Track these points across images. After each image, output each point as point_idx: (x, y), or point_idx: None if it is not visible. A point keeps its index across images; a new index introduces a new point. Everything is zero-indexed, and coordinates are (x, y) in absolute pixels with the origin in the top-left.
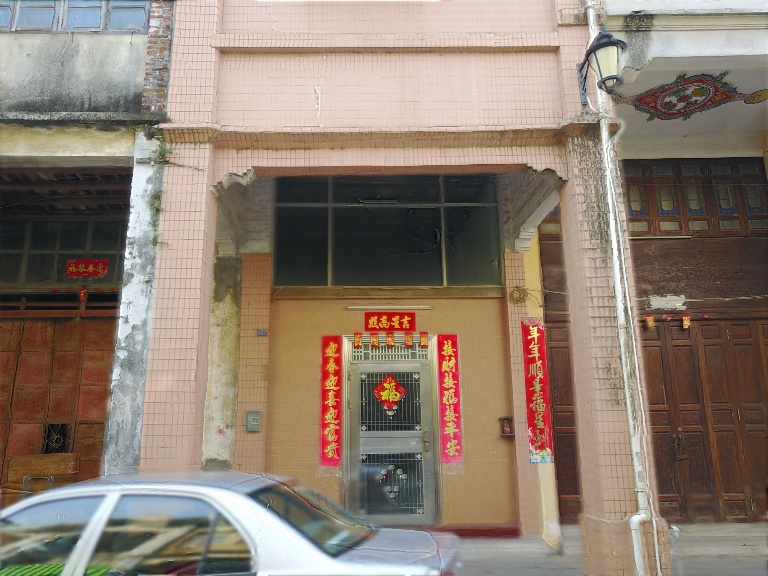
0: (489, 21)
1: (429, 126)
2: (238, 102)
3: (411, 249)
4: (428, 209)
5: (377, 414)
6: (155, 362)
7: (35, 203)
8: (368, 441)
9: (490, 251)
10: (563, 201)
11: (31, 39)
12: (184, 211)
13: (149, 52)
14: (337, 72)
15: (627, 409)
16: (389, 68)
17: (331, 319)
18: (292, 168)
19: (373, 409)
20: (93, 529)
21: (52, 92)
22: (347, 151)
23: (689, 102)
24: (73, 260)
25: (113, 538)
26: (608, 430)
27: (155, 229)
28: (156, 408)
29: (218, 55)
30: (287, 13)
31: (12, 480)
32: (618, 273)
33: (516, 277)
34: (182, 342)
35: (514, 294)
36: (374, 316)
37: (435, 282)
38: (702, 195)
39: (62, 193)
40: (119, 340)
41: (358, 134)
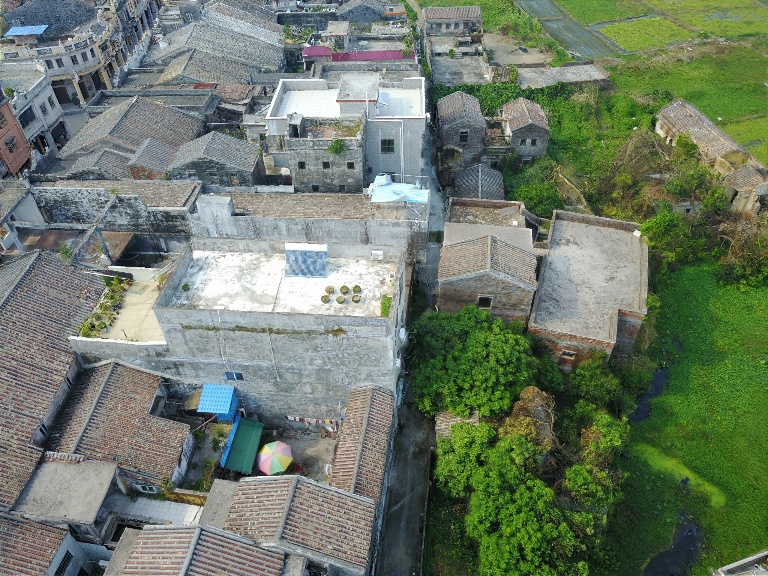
0: None
1: (23, 160)
2: None
3: None
4: None
5: None
6: None
7: None
8: None
9: None
10: None
11: None
12: None
13: None
14: None
15: None
16: None
17: None
18: None
19: None
20: None
21: None
22: None
23: None
24: None
25: None
26: None
27: None
28: None
29: None
30: None
31: None
32: None
33: None
34: None
35: None
36: None
37: None
38: None
39: None
40: None
41: None
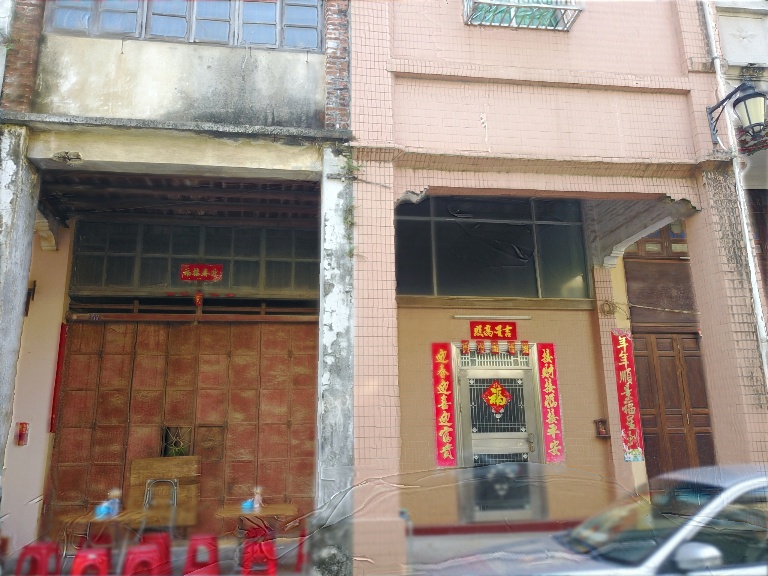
0: (628, 63)
1: (584, 156)
2: (413, 124)
3: (502, 262)
4: (495, 224)
5: (486, 417)
6: (361, 368)
7: (161, 207)
8: (480, 442)
9: (571, 266)
10: (693, 228)
11: (210, 51)
12: (375, 226)
13: (329, 72)
14: (500, 101)
15: None
16: (545, 100)
17: (439, 327)
18: (463, 188)
19: (482, 412)
20: (513, 517)
21: (235, 105)
22: (512, 175)
23: (759, 141)
24: (187, 264)
25: (530, 524)
26: (755, 430)
27: (350, 242)
28: (365, 411)
29: (394, 79)
30: (450, 43)
31: (135, 483)
32: (757, 294)
33: (605, 291)
34: (384, 349)
35: (605, 307)
36: (479, 325)
37: (531, 294)
38: (755, 222)
39: (193, 199)
40: (326, 347)
41: (526, 160)
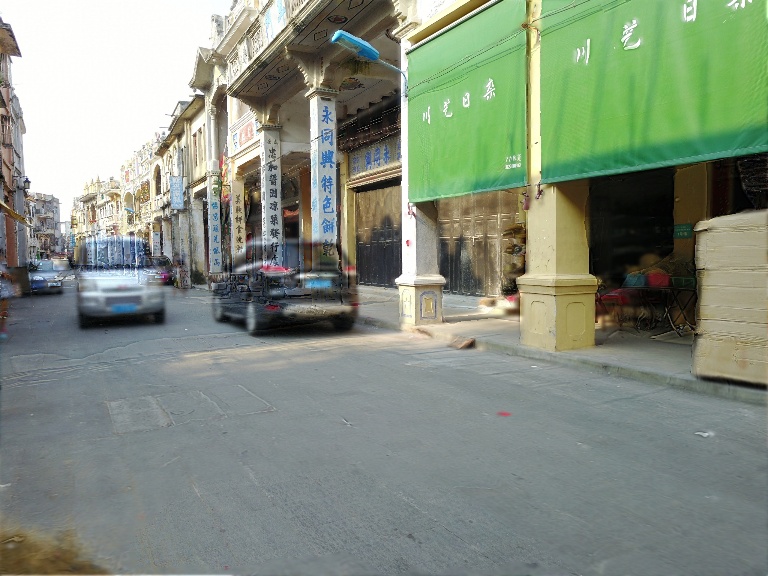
0: None
1: None
2: None
3: None
4: None
5: None
6: None
7: None
8: None
9: None
10: None
11: None
12: None
13: None
14: None
15: (17, 252)
16: None
17: None
18: None
19: None
20: None
21: None
22: None
23: None
24: None
25: None
26: None
27: None
28: None
29: None
30: None
31: None
32: None
33: None
34: None
35: None
36: None
37: None
38: None
39: None
40: None
41: None
